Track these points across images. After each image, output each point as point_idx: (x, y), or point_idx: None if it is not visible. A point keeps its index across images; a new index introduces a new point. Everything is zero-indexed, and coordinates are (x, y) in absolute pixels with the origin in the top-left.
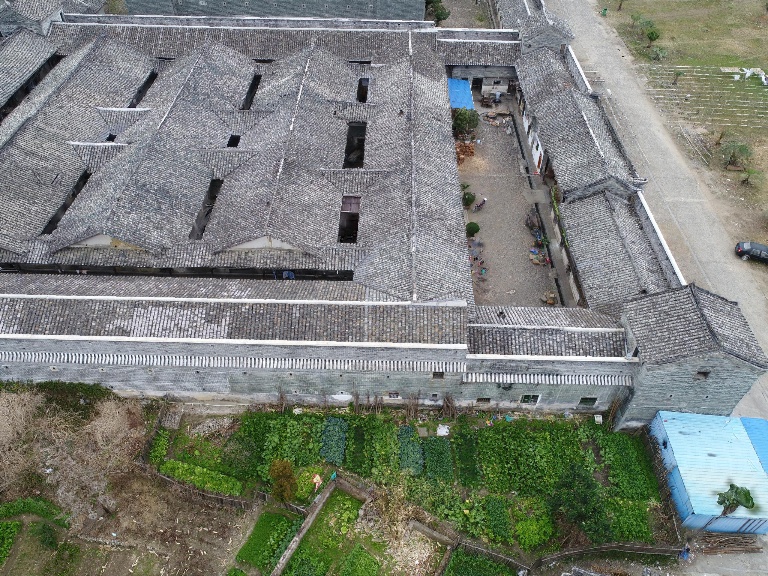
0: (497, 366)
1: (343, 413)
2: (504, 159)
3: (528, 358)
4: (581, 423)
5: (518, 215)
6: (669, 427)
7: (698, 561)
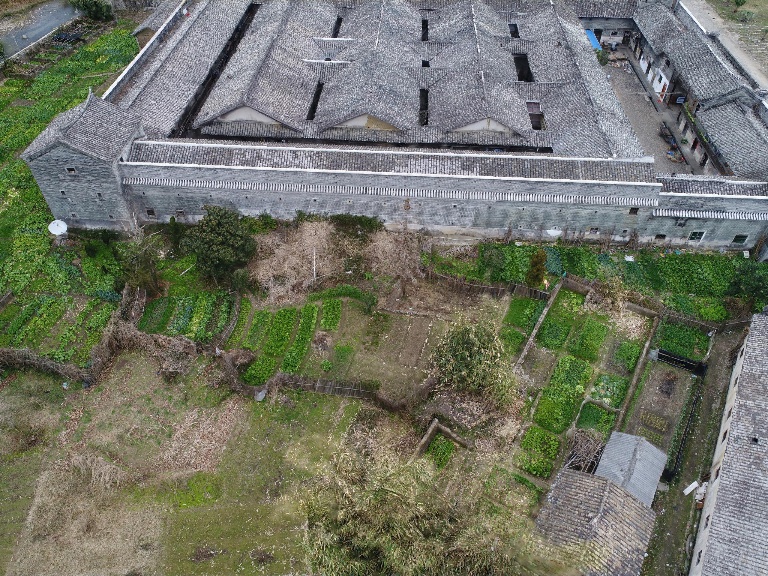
0: (680, 203)
1: (553, 246)
2: (630, 91)
3: (705, 195)
4: (733, 257)
5: (651, 129)
6: None
7: None
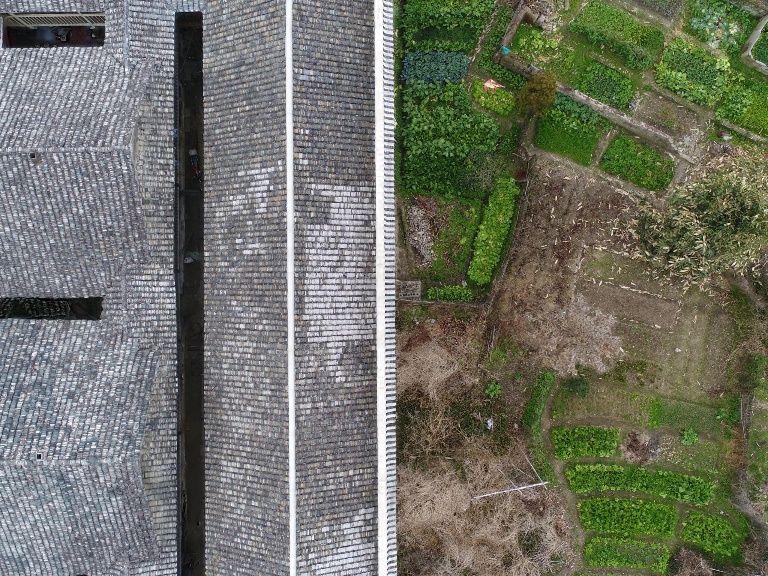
0: None
1: None
2: None
3: None
4: None
5: None
6: None
7: None
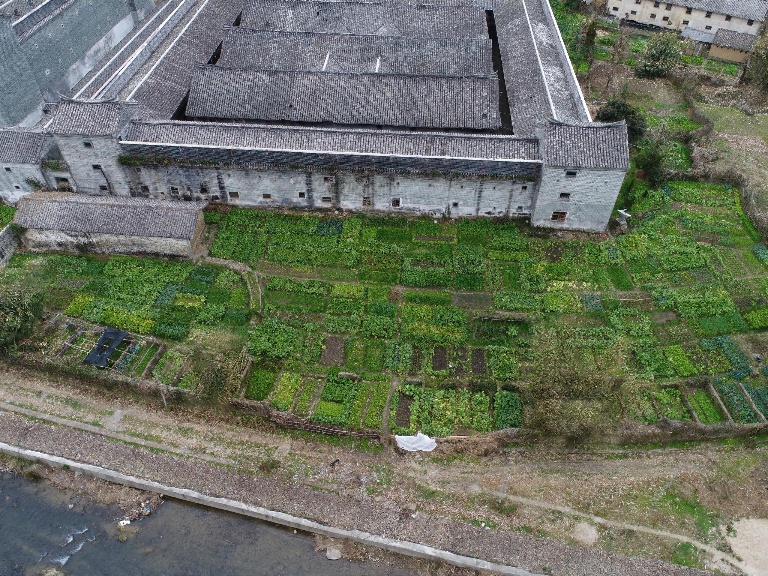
0: None
1: None
2: None
3: None
4: None
5: None
6: None
7: None
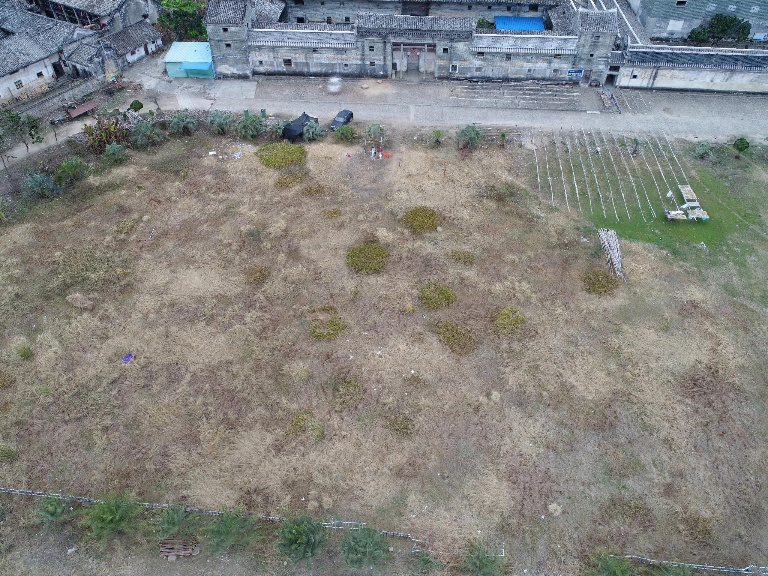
0: None
1: None
2: None
3: None
4: None
5: None
6: None
7: None
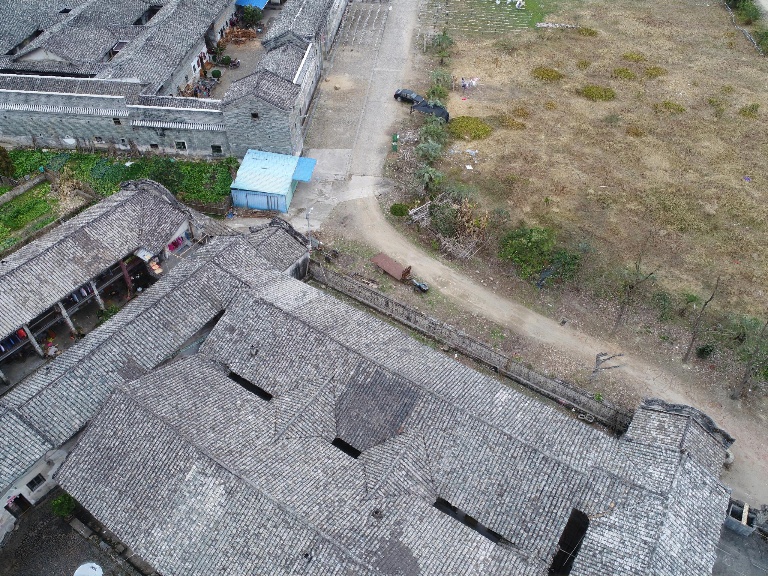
0: (148, 114)
1: (72, 153)
2: None
3: (162, 108)
4: None
5: None
6: (248, 155)
7: (237, 219)
